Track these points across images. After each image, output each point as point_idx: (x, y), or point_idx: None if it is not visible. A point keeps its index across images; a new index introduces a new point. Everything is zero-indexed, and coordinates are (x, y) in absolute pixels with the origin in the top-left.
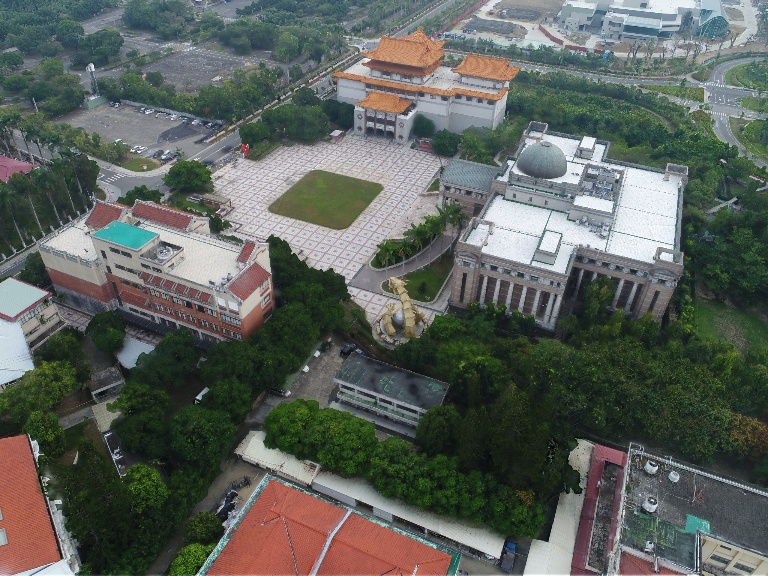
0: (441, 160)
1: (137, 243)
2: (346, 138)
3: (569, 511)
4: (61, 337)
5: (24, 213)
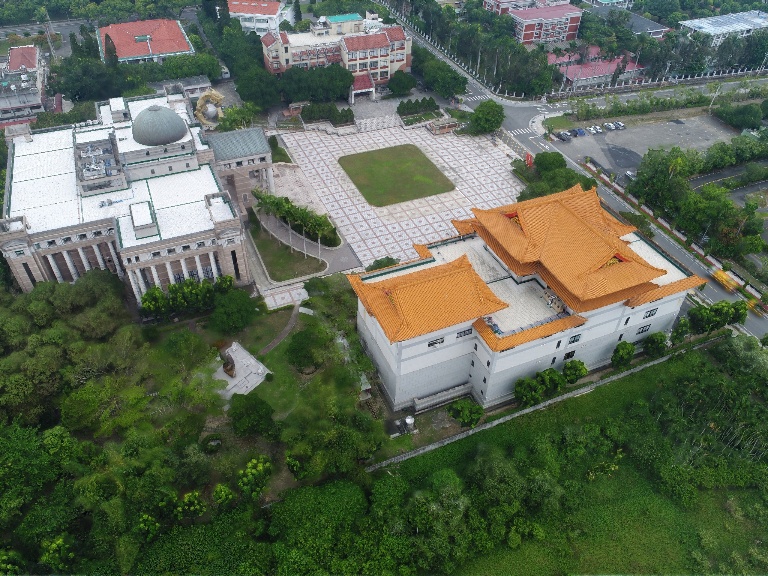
0: None
1: (332, 18)
2: None
3: (68, 101)
4: None
5: (471, 49)
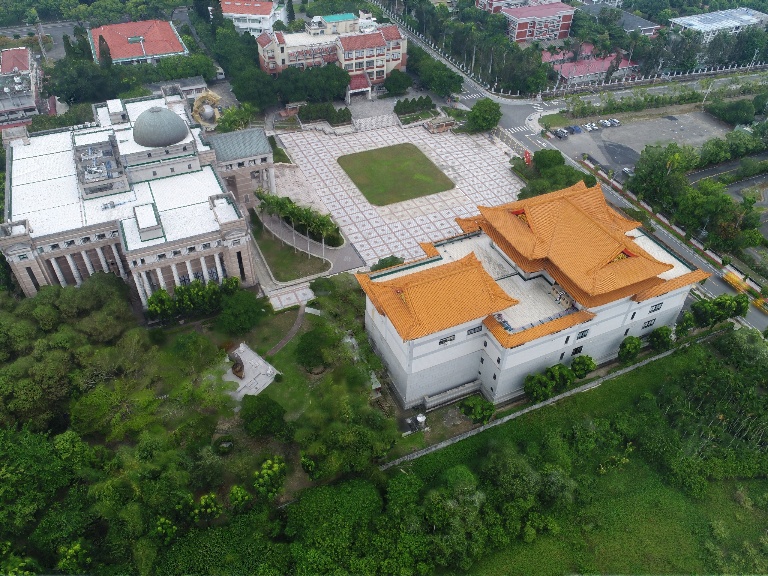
0: None
1: None
2: None
3: None
4: None
5: (466, 48)
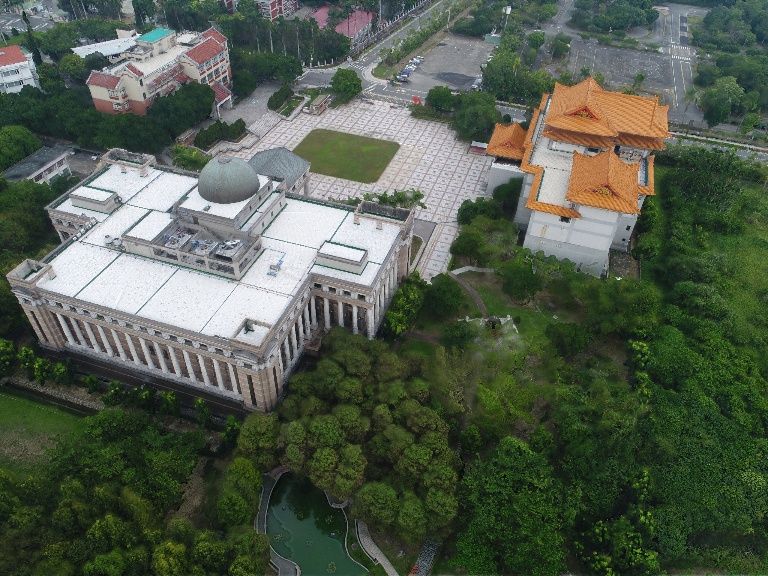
0: (452, 222)
1: None
2: (485, 157)
3: None
4: (100, 56)
5: (260, 36)
